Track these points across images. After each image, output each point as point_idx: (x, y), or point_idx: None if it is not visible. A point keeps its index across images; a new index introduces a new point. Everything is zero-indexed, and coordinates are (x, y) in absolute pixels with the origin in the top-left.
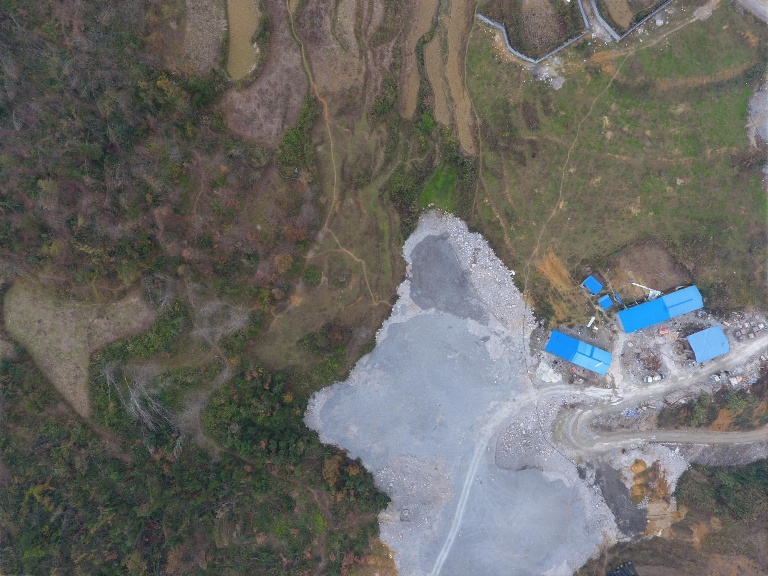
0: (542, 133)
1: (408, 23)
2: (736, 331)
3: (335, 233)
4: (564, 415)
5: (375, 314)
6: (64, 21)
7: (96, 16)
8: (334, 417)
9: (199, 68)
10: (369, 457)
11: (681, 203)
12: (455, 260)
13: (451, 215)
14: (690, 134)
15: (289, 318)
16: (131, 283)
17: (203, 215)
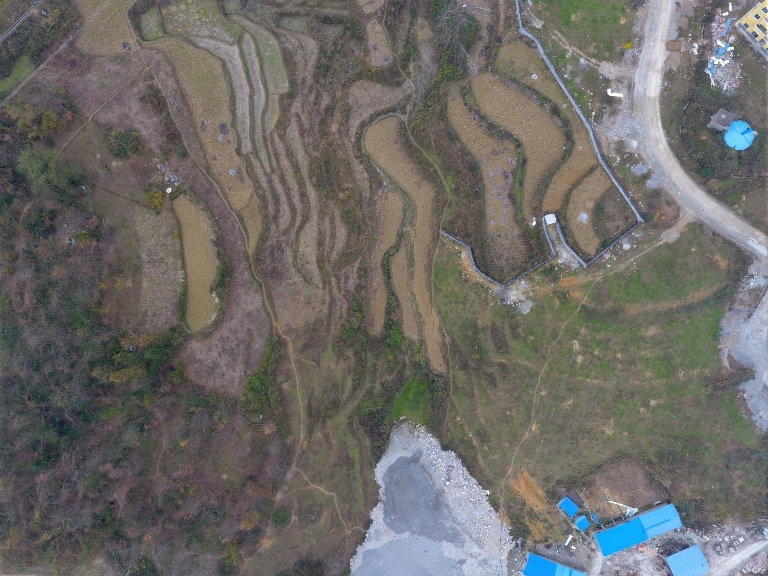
0: (512, 357)
1: (373, 238)
2: (716, 545)
3: (304, 471)
4: None
5: (349, 541)
6: (15, 295)
7: (48, 287)
8: None
9: (157, 325)
10: None
11: (655, 423)
12: (428, 483)
13: (423, 429)
14: (662, 356)
15: (260, 560)
16: None
17: (166, 473)
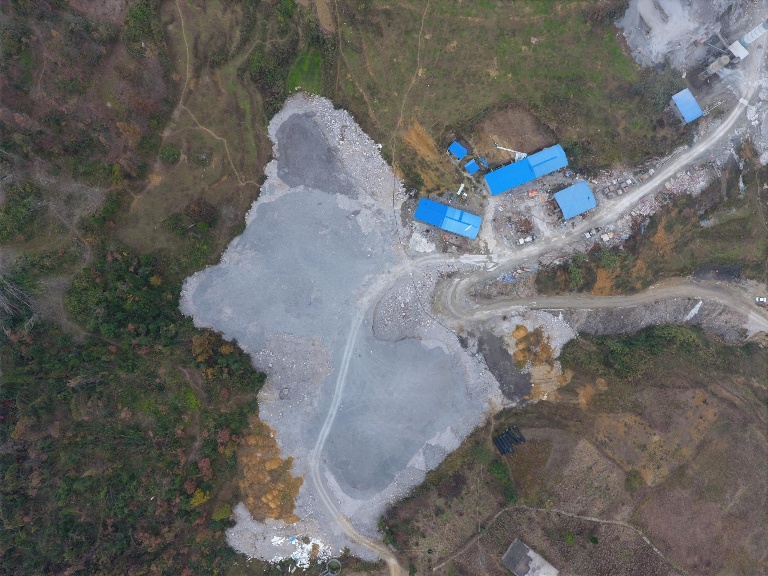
0: (395, 1)
1: None
2: (604, 188)
3: (191, 110)
4: (442, 286)
5: (243, 195)
6: None
7: None
8: (207, 300)
9: None
10: (244, 337)
11: (538, 62)
12: (320, 136)
13: (318, 96)
14: None
15: (150, 198)
16: None
17: (48, 92)
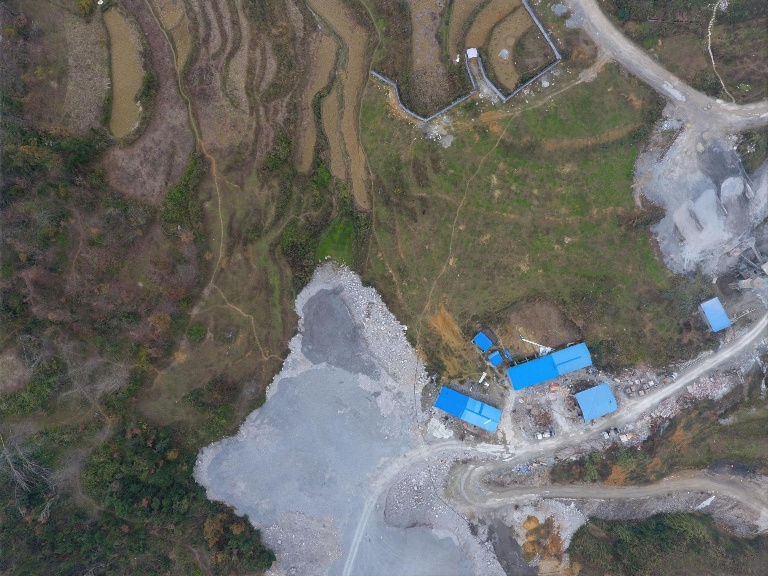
0: (432, 190)
1: (304, 78)
2: (626, 388)
3: (221, 289)
4: (456, 471)
5: (265, 369)
6: None
7: None
8: (222, 473)
9: (79, 126)
10: (256, 514)
11: (569, 261)
12: (347, 315)
13: (347, 268)
14: (577, 193)
15: (173, 374)
16: (6, 341)
17: (82, 273)
